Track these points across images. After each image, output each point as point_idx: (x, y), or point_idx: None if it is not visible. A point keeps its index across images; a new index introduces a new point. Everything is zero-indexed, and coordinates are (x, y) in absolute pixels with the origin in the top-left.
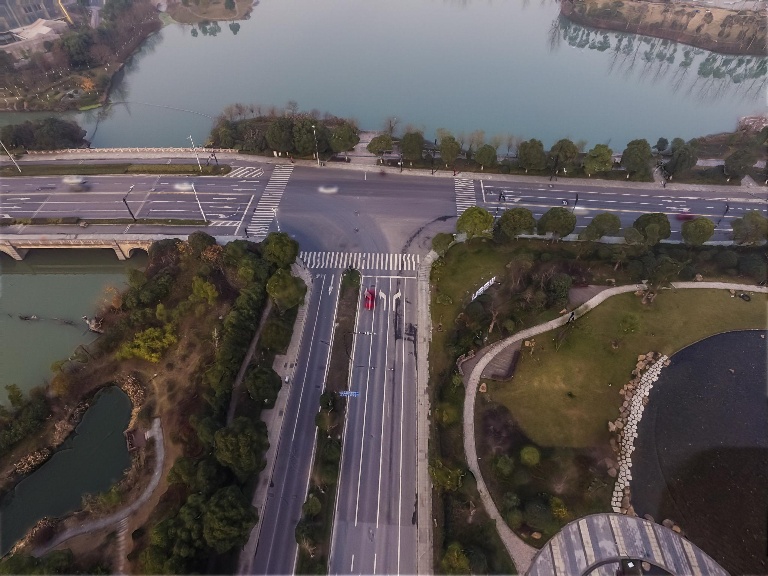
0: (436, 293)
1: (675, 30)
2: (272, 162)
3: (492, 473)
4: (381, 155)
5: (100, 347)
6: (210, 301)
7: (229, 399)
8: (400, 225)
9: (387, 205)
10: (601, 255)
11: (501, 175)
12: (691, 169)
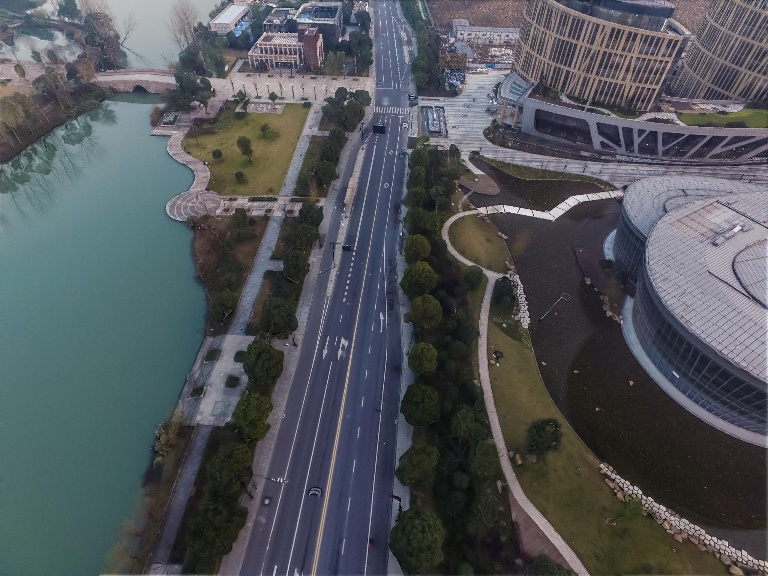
0: None
1: None
2: None
3: None
4: None
5: None
6: None
7: None
8: None
9: None
10: (467, 487)
11: None
12: None
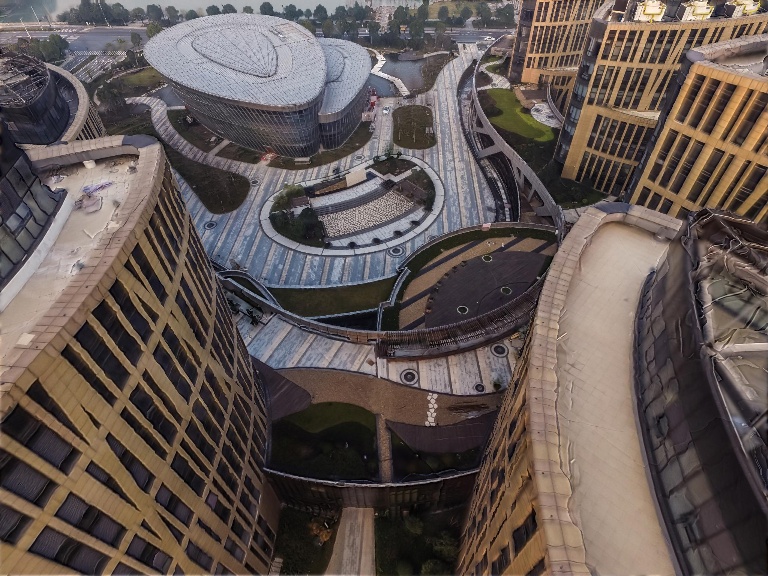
0: None
1: None
2: (84, 27)
3: None
4: (141, 20)
5: None
6: None
7: None
8: None
9: None
10: None
11: None
12: None
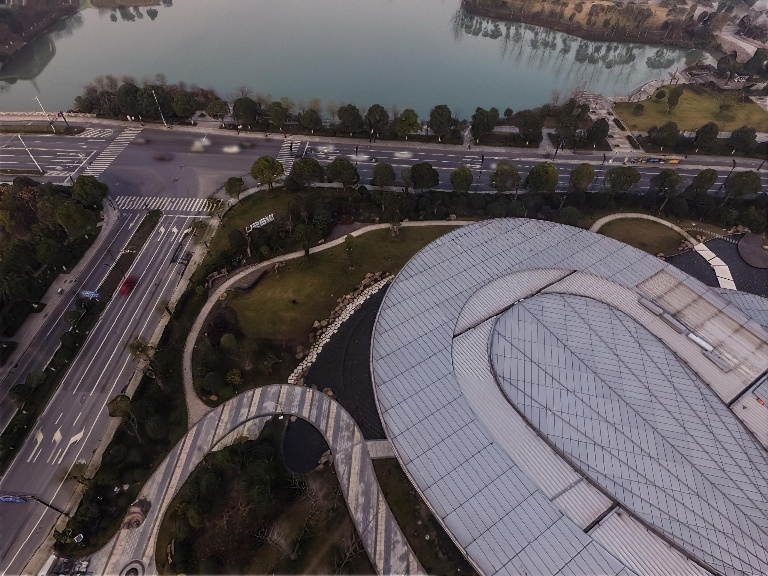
0: (222, 228)
1: (552, 19)
2: (124, 125)
3: (200, 356)
4: (221, 119)
5: None
6: (7, 229)
7: (1, 303)
8: (217, 176)
9: (213, 160)
10: (372, 198)
11: (328, 138)
12: (501, 134)
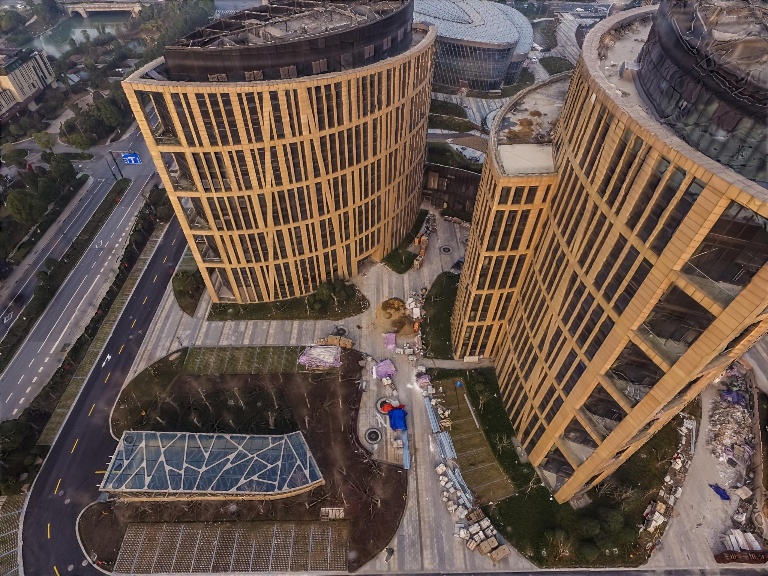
0: None
1: None
2: None
3: None
4: None
5: (132, 25)
6: (176, 10)
7: None
8: None
9: (260, 1)
10: None
11: None
12: None
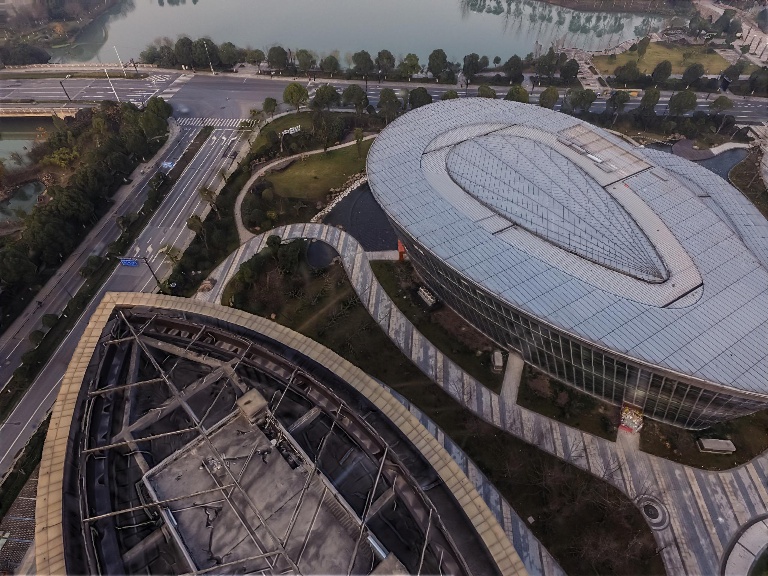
0: (260, 137)
1: None
2: (180, 72)
3: (247, 207)
4: (258, 66)
5: (30, 157)
6: (102, 131)
7: None
8: (255, 105)
9: (252, 95)
10: (378, 115)
11: (345, 80)
12: (489, 77)
